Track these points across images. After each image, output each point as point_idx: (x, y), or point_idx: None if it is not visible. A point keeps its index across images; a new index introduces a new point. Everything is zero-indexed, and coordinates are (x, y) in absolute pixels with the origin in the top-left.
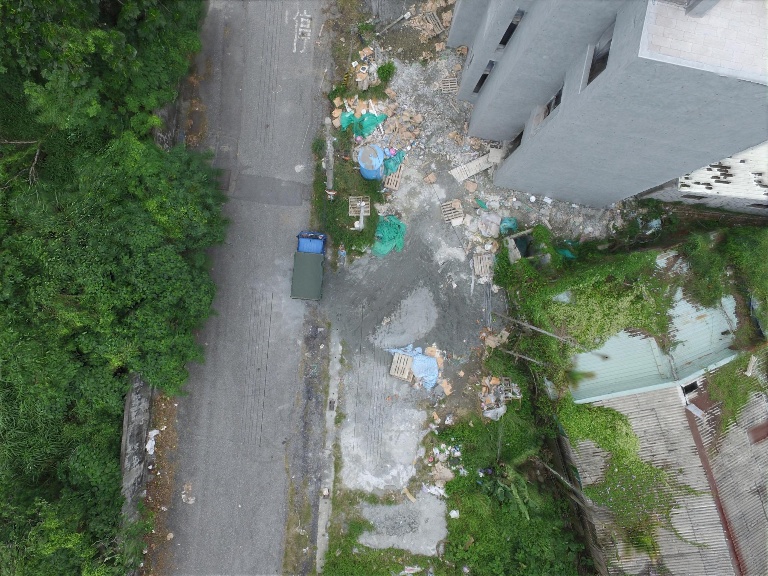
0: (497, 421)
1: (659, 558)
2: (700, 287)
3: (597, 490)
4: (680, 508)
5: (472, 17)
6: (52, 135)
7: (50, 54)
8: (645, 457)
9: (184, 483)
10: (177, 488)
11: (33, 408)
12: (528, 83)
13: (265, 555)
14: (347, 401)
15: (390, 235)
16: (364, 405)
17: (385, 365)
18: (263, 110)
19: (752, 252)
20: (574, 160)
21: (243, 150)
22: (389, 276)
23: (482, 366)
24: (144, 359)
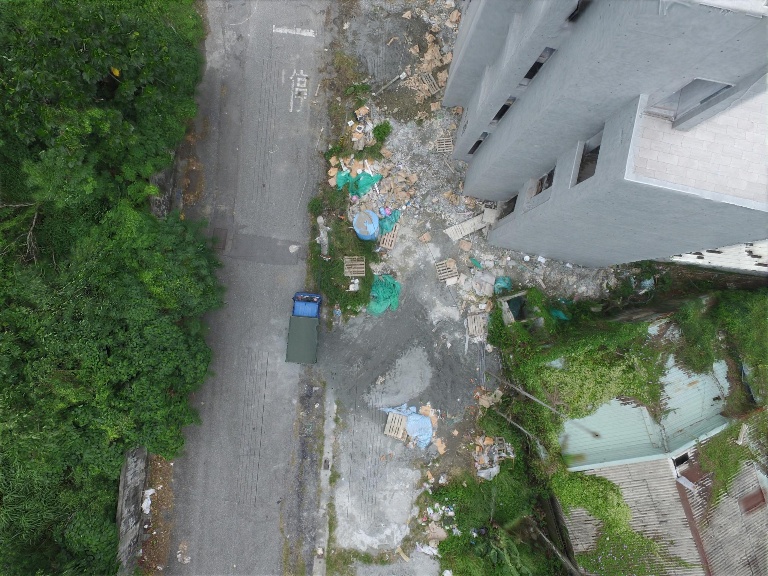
0: (491, 481)
1: None
2: (692, 355)
3: (589, 558)
4: None
5: (466, 84)
6: (50, 197)
7: (48, 132)
8: (636, 527)
9: (179, 543)
10: (172, 548)
11: (30, 473)
12: (520, 162)
13: None
14: (342, 460)
15: (385, 295)
16: (358, 464)
17: (380, 424)
18: (259, 169)
19: (744, 319)
20: (566, 236)
21: (239, 209)
22: (384, 335)
23: (476, 425)
24: (139, 431)
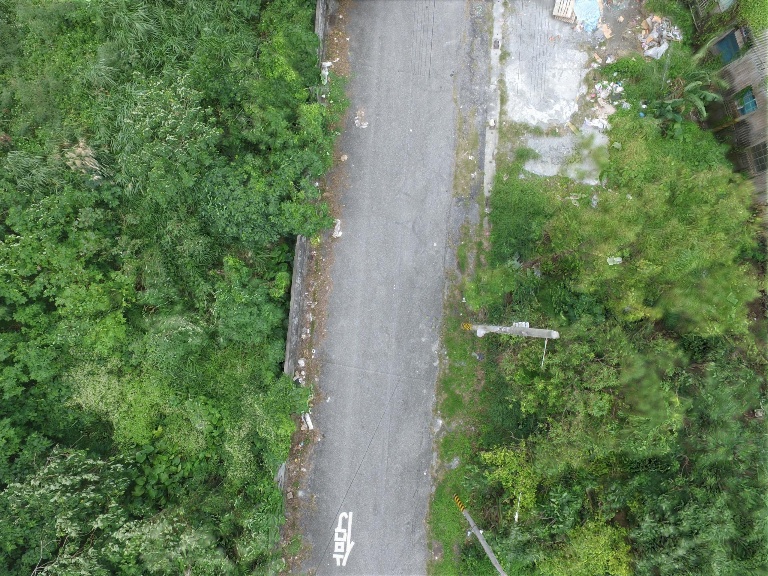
0: (658, 59)
1: None
2: None
3: None
4: None
5: None
6: None
7: None
8: None
9: (357, 109)
10: (350, 114)
11: (227, 7)
12: None
13: (436, 176)
14: (511, 40)
15: None
16: (528, 44)
17: (547, 8)
18: None
19: None
20: None
21: None
22: None
23: (642, 10)
24: None
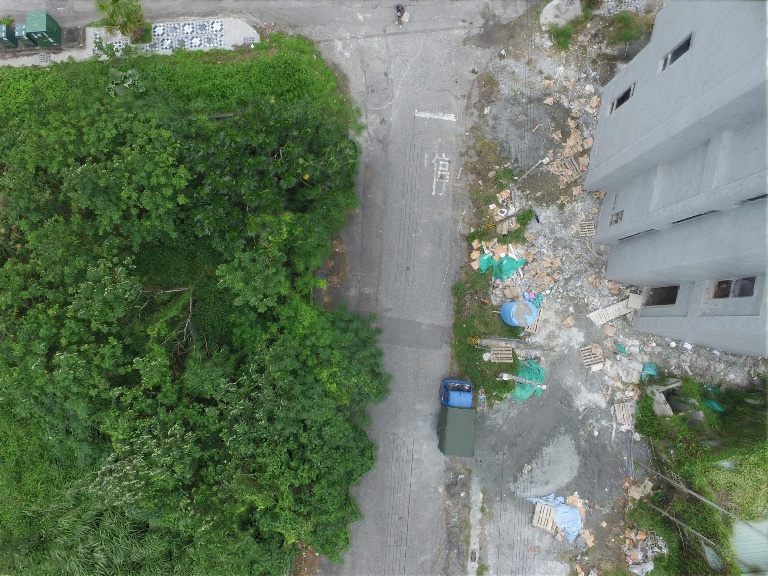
0: None
1: None
2: None
3: None
4: None
5: (624, 176)
6: (203, 282)
7: (236, 234)
8: None
9: None
10: None
11: (186, 568)
12: (711, 269)
13: None
14: (489, 552)
15: None
16: (506, 557)
17: (527, 514)
18: (403, 252)
19: None
20: (751, 341)
21: (383, 292)
22: (529, 422)
23: (626, 517)
24: (314, 534)
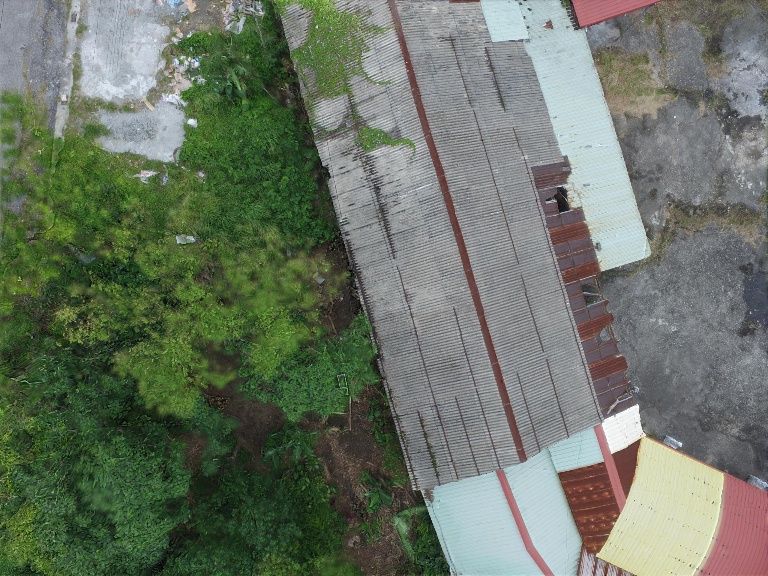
0: None
1: (354, 107)
2: None
3: (300, 50)
4: (370, 51)
5: None
6: None
7: None
8: (341, 7)
9: None
10: None
11: None
12: None
13: None
14: (89, 13)
15: None
16: (106, 18)
17: None
18: None
19: None
20: None
21: None
22: None
23: None
24: None
